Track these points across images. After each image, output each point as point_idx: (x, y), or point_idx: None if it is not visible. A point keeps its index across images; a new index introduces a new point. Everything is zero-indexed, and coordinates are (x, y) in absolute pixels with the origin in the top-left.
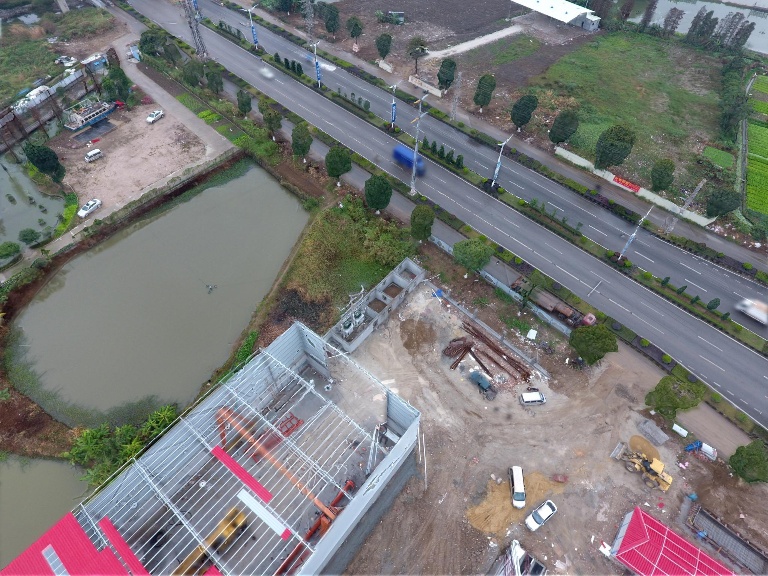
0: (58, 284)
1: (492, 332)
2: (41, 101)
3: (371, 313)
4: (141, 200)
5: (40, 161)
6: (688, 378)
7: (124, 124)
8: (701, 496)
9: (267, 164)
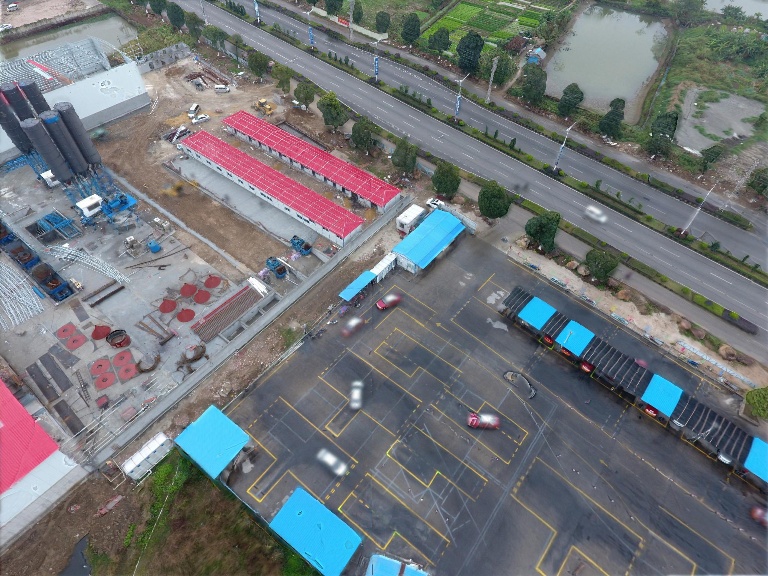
0: None
1: (217, 71)
2: None
3: None
4: (36, 23)
5: None
6: (313, 86)
7: None
8: (287, 118)
9: (122, 12)
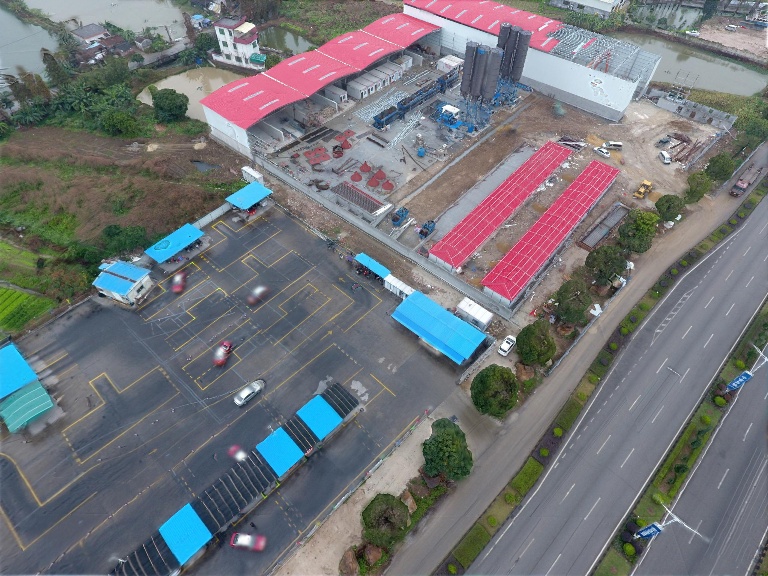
0: (643, 43)
1: None
2: (760, 7)
3: None
4: (709, 42)
5: (707, 3)
6: None
7: (767, 33)
8: None
9: None
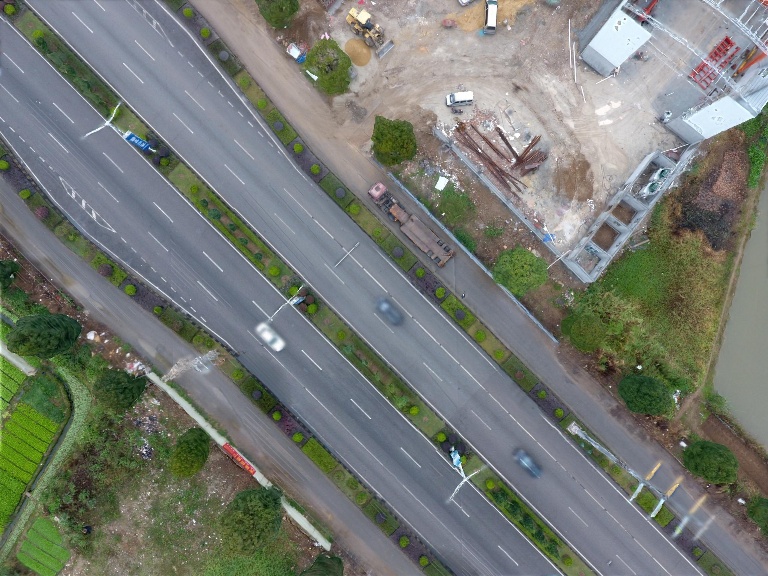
0: None
1: (490, 182)
2: None
3: (632, 200)
4: None
5: None
6: (283, 125)
7: None
8: (321, 10)
9: None
